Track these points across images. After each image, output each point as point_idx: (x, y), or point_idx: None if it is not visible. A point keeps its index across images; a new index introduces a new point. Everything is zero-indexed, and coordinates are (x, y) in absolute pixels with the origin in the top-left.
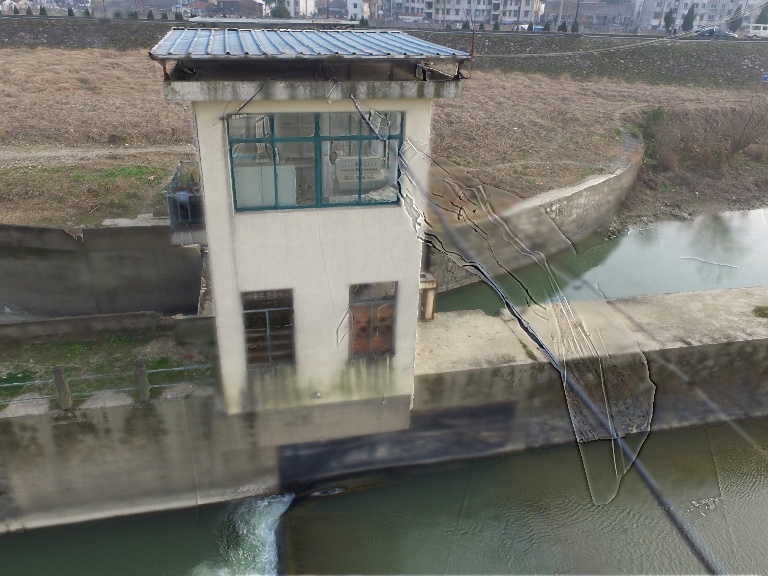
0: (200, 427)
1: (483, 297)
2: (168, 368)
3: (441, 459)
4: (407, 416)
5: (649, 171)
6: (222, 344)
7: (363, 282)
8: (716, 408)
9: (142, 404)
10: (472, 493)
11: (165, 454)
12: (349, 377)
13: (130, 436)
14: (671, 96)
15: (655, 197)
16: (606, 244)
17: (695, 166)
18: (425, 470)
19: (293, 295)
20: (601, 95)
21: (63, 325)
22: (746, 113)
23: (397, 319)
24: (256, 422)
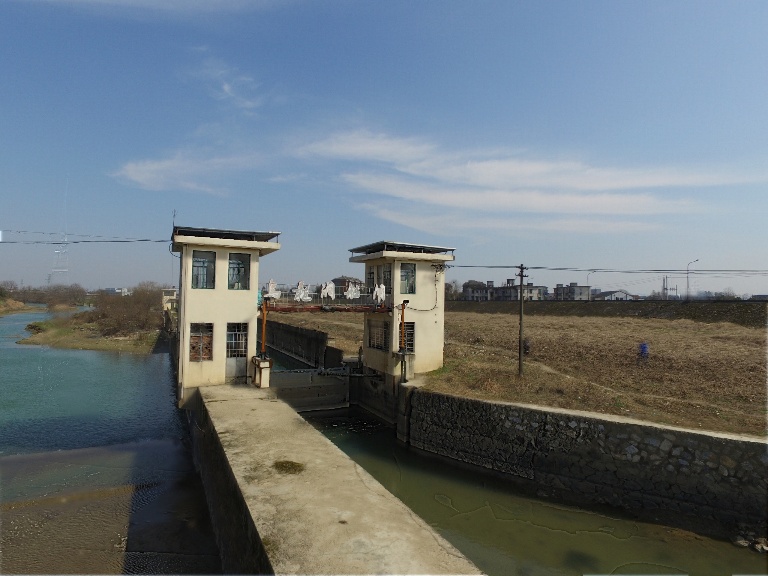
0: None
1: (464, 482)
2: None
3: None
4: None
5: None
6: None
7: None
8: None
9: None
10: None
11: None
12: None
13: None
14: None
15: None
16: (725, 544)
17: None
18: None
19: None
20: None
21: None
22: None
23: None
24: None
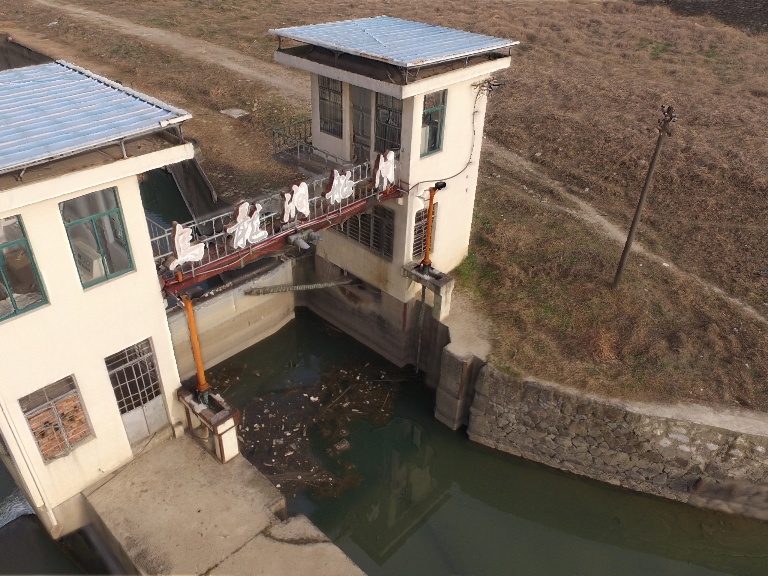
0: None
1: (565, 492)
2: None
3: None
4: None
5: None
6: None
7: None
8: None
9: None
10: None
11: None
12: None
13: None
14: None
15: None
16: None
17: None
18: None
19: None
20: None
21: None
22: None
23: None
24: None
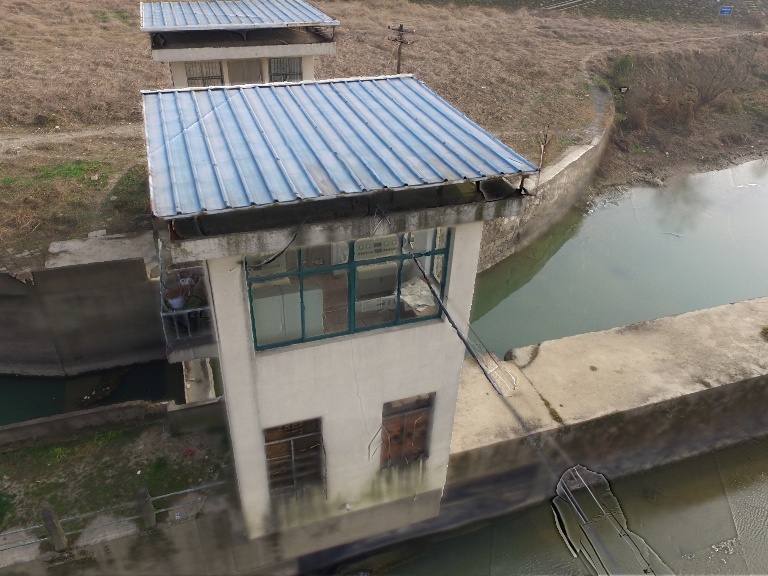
0: (214, 540)
1: None
2: (170, 477)
3: (463, 523)
4: (437, 506)
5: (620, 131)
6: (243, 480)
7: (399, 398)
8: (725, 435)
9: (148, 531)
10: (497, 556)
11: (176, 570)
12: (380, 484)
13: (136, 561)
14: (633, 36)
15: (627, 161)
16: (585, 221)
17: (663, 121)
18: (447, 536)
19: (322, 422)
20: (562, 35)
21: (36, 428)
22: (715, 65)
23: (433, 426)
24: (280, 540)
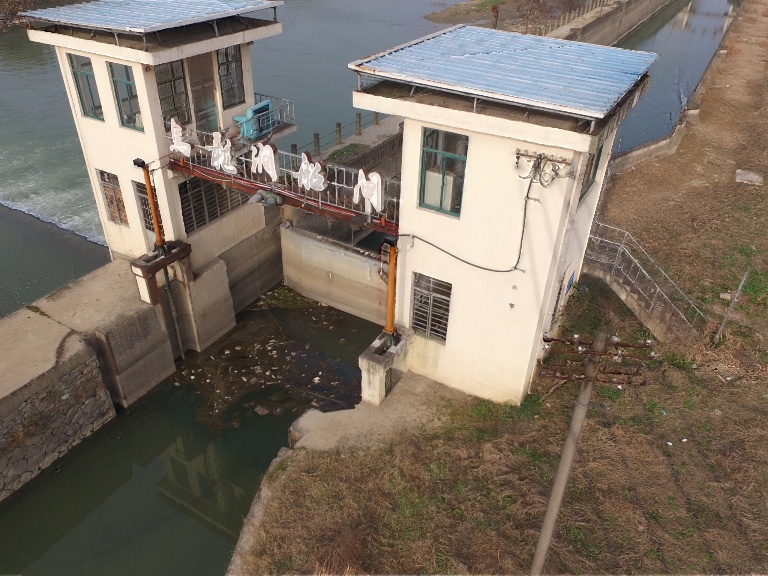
0: None
1: None
2: None
3: None
4: None
5: None
6: None
7: None
8: None
9: None
10: None
11: None
12: None
13: None
14: None
15: None
16: None
17: None
18: None
19: None
20: None
21: None
22: None
23: None
24: None
